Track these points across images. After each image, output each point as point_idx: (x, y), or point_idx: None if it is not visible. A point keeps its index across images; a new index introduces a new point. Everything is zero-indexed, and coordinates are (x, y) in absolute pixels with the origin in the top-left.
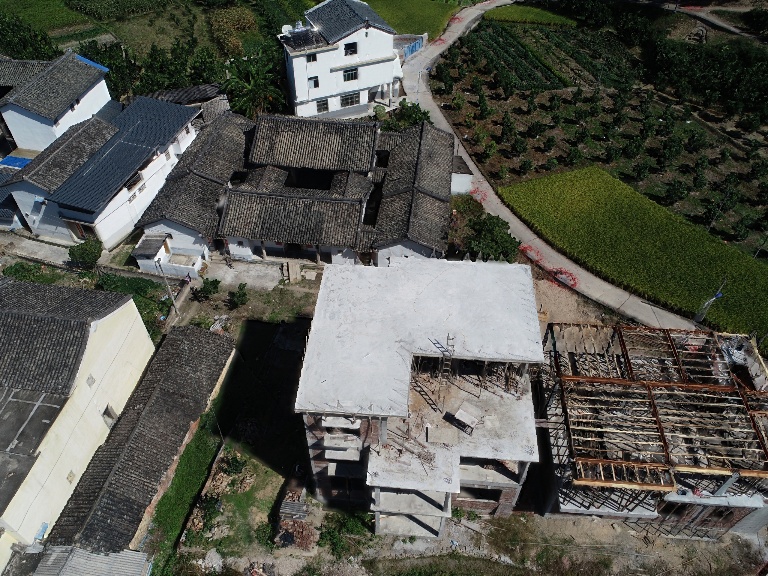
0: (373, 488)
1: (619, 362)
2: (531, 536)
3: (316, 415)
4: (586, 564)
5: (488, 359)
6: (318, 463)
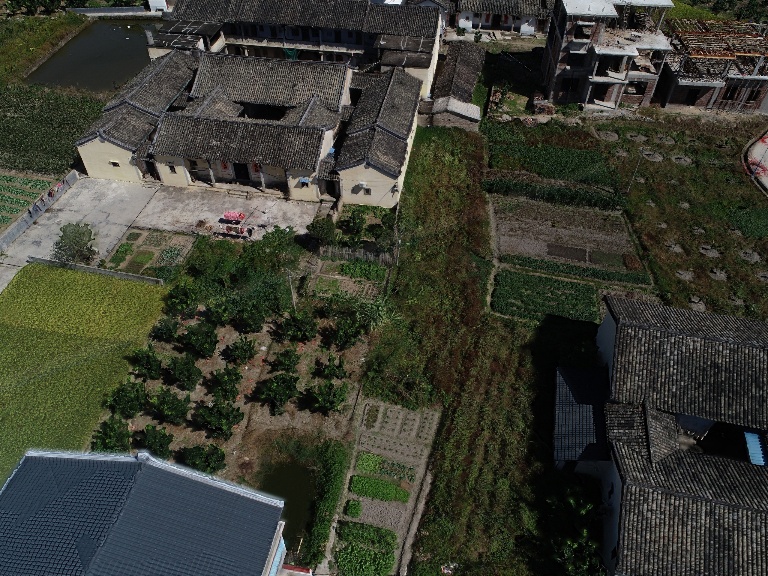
0: (583, 86)
1: None
2: (660, 113)
3: (574, 21)
4: (688, 120)
5: (648, 5)
6: (561, 66)
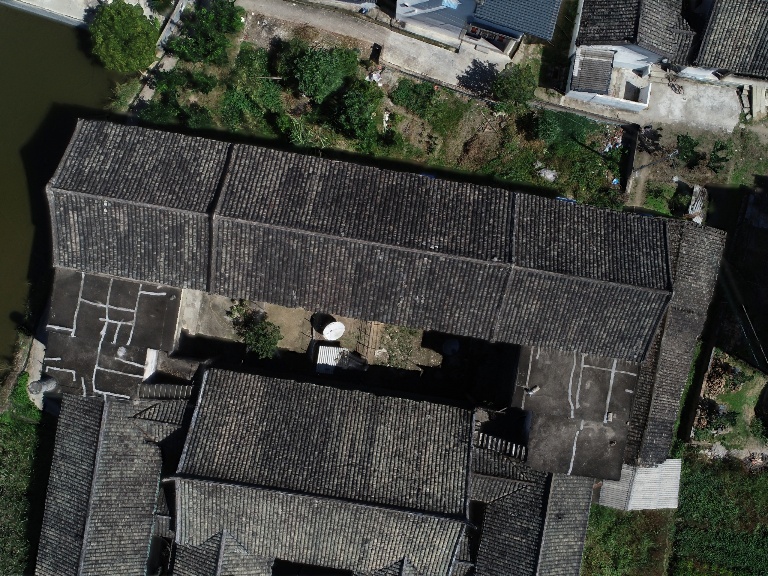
0: None
1: None
2: None
3: None
4: None
5: None
6: None
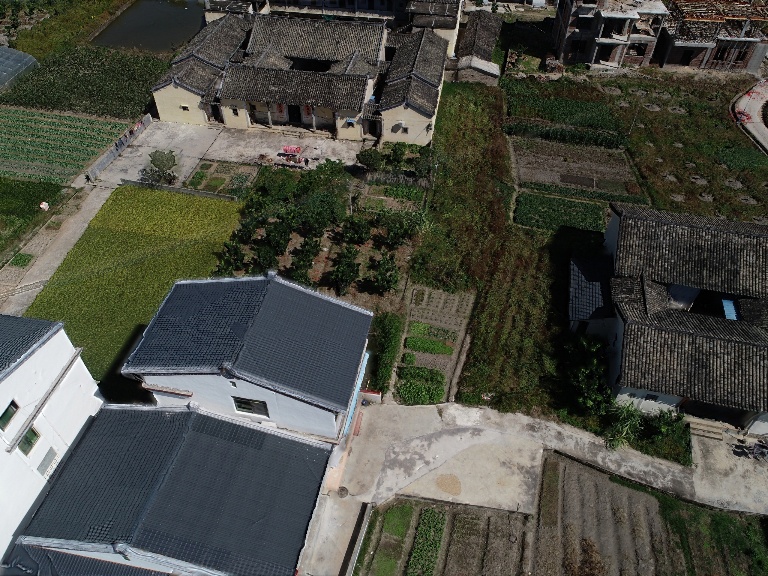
0: (590, 47)
1: None
2: None
3: None
4: (683, 78)
5: None
6: (571, 29)
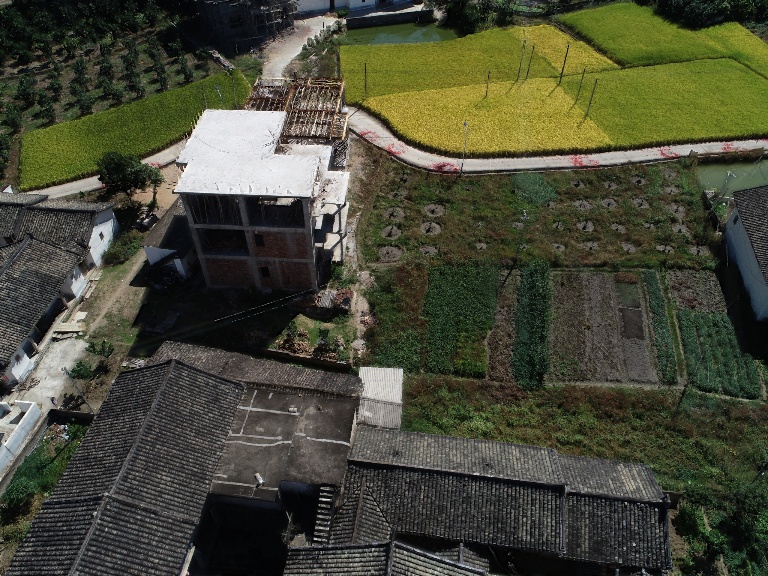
0: None
1: None
2: None
3: None
4: (361, 187)
5: (281, 130)
6: None
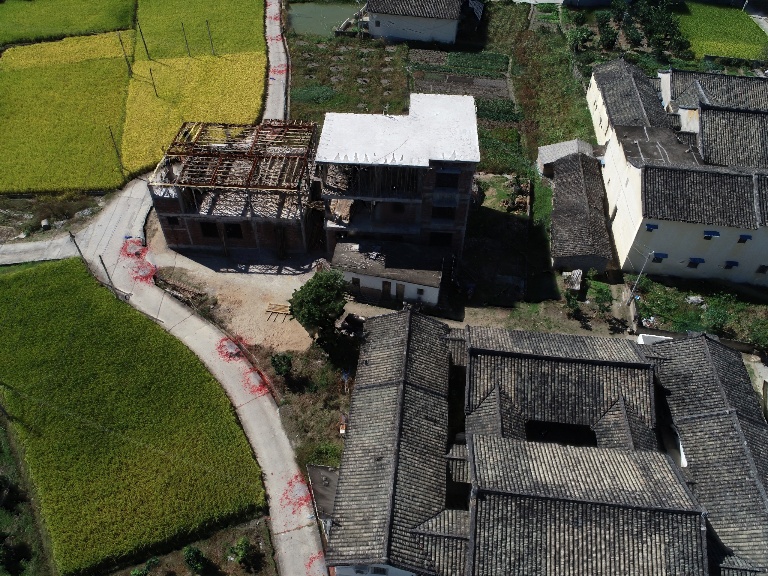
0: None
1: (244, 211)
2: None
3: None
4: None
5: None
6: None
